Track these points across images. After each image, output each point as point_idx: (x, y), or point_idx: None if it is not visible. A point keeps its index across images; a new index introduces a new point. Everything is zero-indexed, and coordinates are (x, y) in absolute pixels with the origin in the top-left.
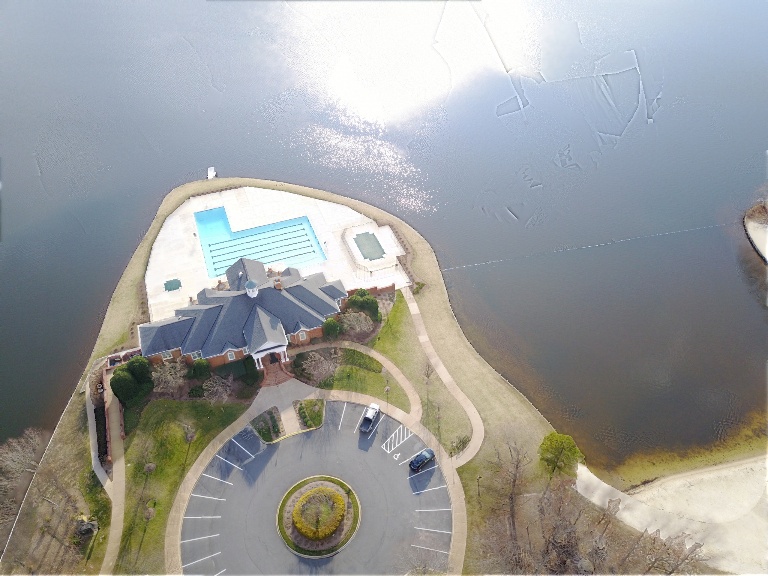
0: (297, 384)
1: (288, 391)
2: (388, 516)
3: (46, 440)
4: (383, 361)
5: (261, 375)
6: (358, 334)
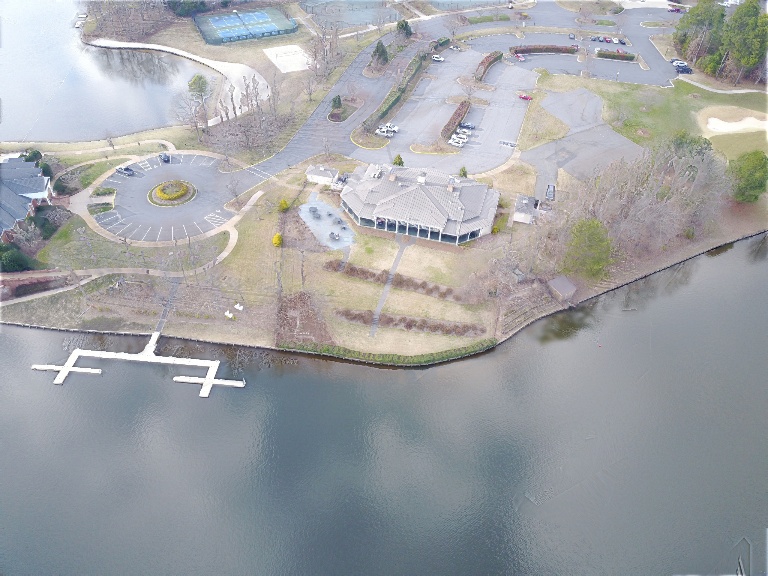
0: (76, 196)
1: (79, 199)
2: (188, 173)
3: (19, 331)
4: (86, 163)
5: (58, 205)
6: (55, 169)
